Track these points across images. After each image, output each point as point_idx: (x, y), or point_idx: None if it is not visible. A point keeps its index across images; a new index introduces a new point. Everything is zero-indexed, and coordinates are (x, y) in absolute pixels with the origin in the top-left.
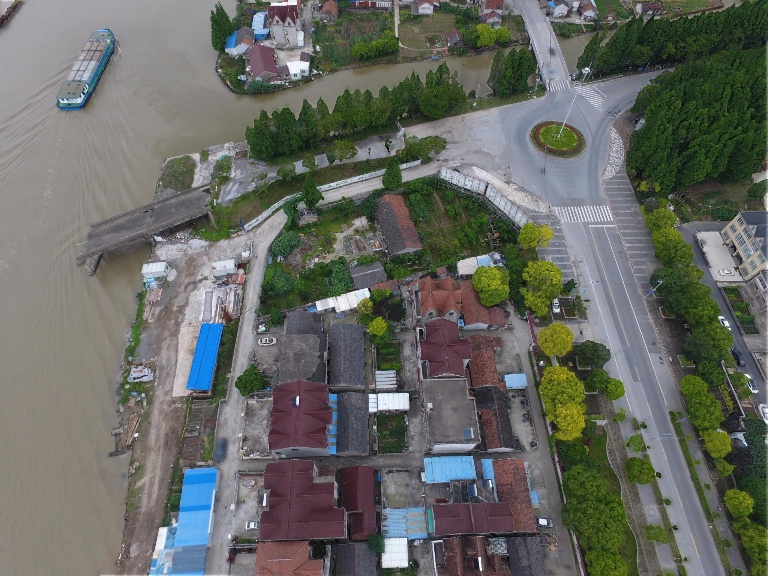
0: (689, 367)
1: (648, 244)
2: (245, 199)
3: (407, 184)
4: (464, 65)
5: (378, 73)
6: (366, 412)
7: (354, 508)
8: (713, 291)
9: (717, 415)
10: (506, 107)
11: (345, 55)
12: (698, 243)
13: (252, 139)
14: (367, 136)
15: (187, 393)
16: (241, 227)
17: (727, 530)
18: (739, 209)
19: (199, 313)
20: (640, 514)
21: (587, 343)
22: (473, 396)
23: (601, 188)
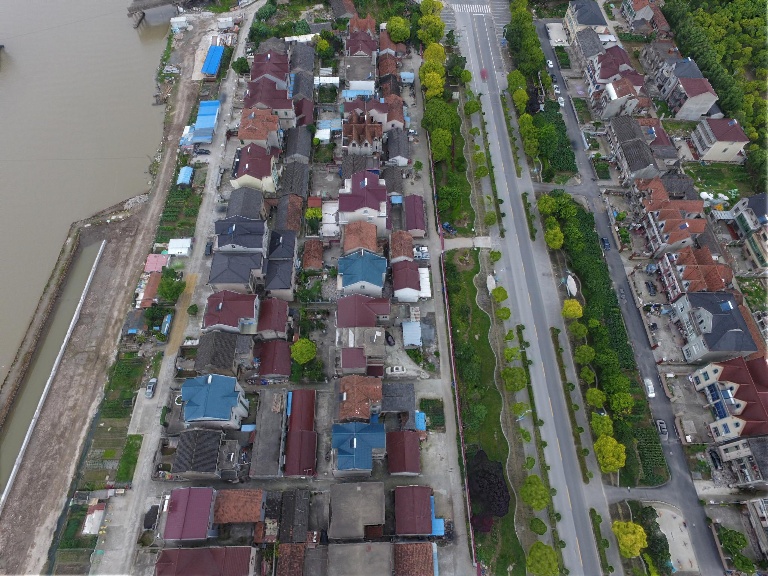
0: None
1: None
2: None
3: None
4: None
5: None
6: (312, 83)
7: (300, 113)
8: (548, 50)
9: (522, 84)
10: None
11: None
12: (546, 28)
13: None
14: None
15: (201, 79)
16: None
17: (520, 140)
18: None
19: (208, 45)
20: None
21: (452, 53)
22: (379, 80)
23: None
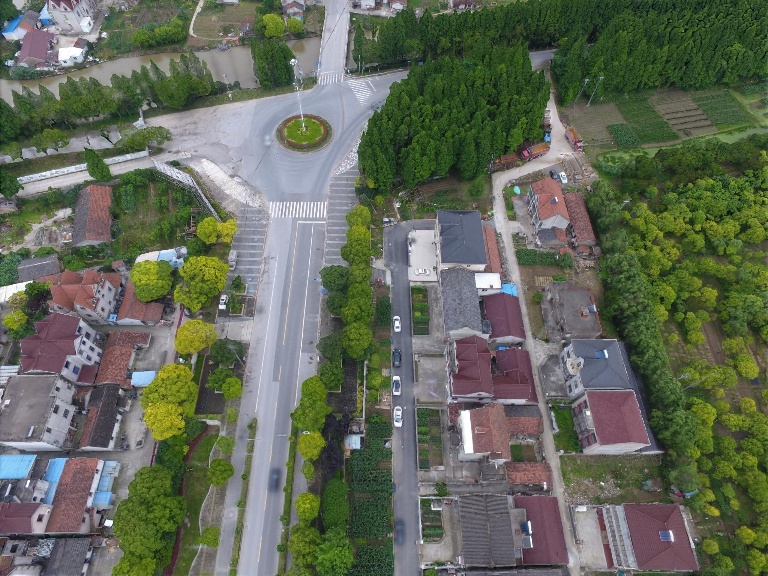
0: None
1: None
2: None
3: None
4: None
5: (161, 62)
6: None
7: None
8: (402, 290)
9: (316, 417)
10: (266, 99)
11: (130, 42)
12: (407, 241)
13: None
14: (104, 125)
15: None
16: None
17: None
18: (467, 208)
19: None
20: (217, 516)
21: (216, 341)
22: (91, 393)
23: (328, 183)
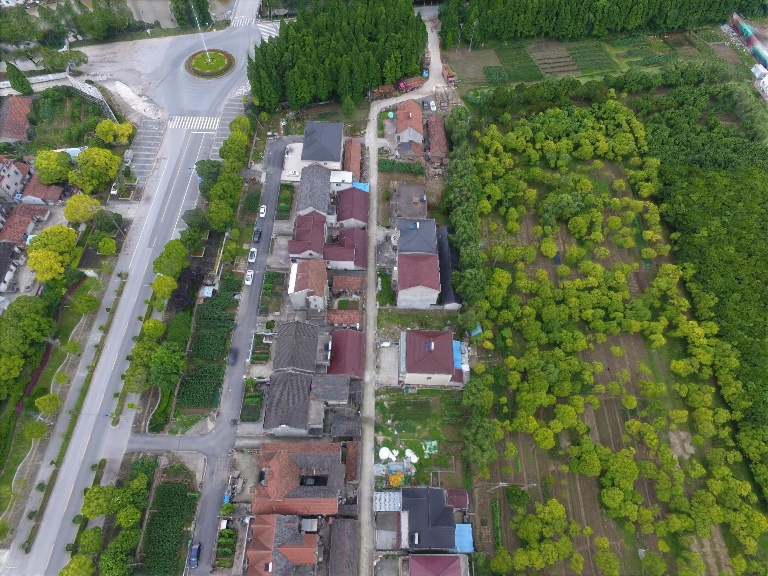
0: (202, 239)
1: None
2: None
3: None
4: None
5: None
6: None
7: None
8: (273, 187)
9: (171, 265)
10: (182, 36)
11: None
12: (285, 151)
13: None
14: (33, 52)
15: None
16: None
17: None
18: None
19: None
20: (84, 339)
21: None
22: None
23: (223, 104)
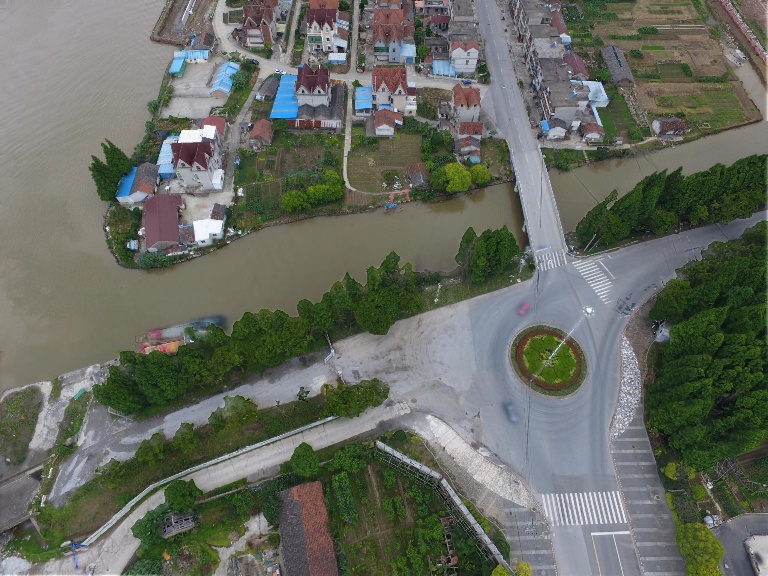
0: None
1: (678, 572)
2: (90, 491)
3: (332, 450)
4: (430, 211)
5: (316, 228)
6: None
7: None
8: None
9: None
10: (479, 299)
11: (275, 202)
12: (751, 562)
13: (102, 400)
14: (283, 359)
15: None
16: (82, 536)
17: None
18: None
19: None
20: None
21: None
22: None
23: (609, 454)
